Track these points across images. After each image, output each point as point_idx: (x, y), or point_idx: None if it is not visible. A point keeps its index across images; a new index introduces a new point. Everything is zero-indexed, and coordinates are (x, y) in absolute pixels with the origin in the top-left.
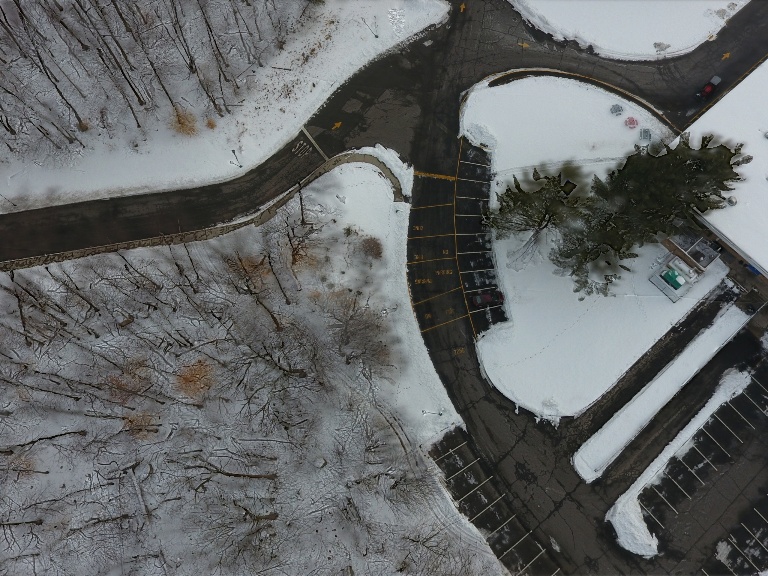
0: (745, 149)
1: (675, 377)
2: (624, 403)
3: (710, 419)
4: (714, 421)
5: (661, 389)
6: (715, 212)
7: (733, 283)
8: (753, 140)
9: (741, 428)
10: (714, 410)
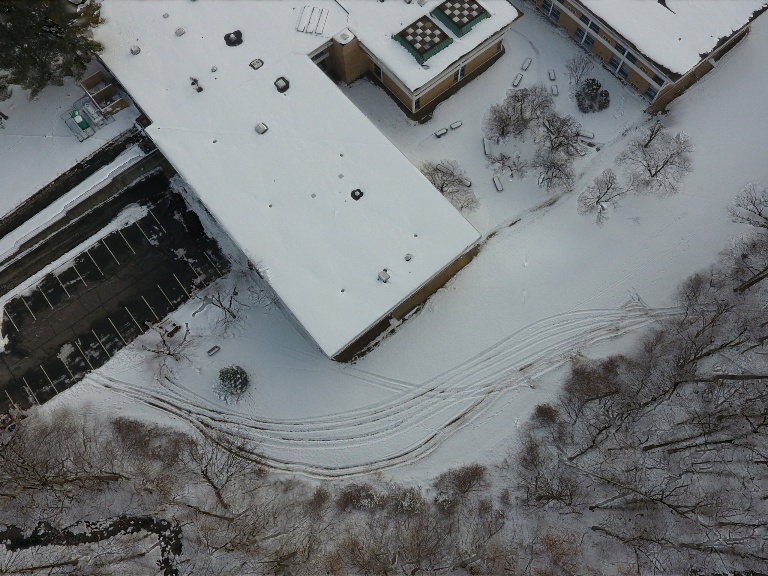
0: (166, 8)
1: (64, 205)
2: (16, 227)
3: (97, 244)
4: (100, 246)
5: (49, 215)
6: (117, 59)
7: (140, 126)
8: (177, 0)
9: (123, 252)
10: (102, 236)
